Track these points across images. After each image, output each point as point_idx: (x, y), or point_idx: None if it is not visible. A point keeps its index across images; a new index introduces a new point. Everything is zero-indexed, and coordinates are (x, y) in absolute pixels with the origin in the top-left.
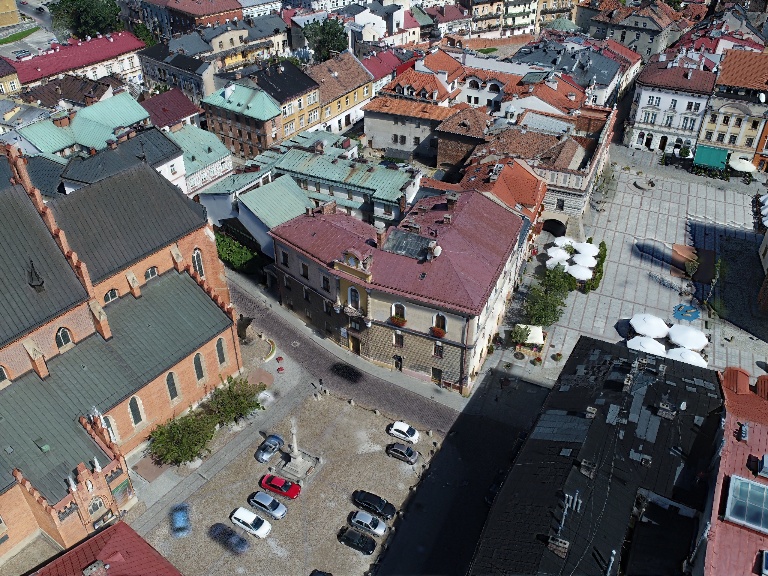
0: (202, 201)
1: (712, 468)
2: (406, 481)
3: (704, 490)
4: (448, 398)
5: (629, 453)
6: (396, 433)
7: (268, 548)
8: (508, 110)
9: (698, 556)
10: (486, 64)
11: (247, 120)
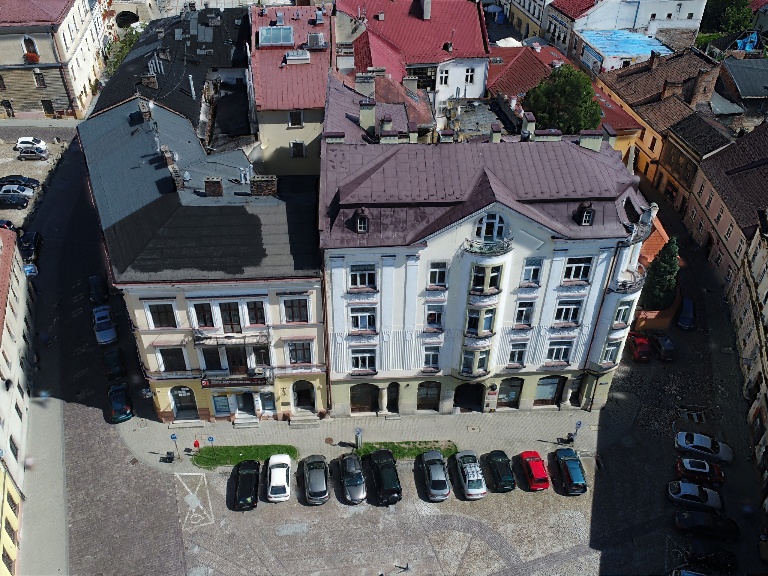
0: None
1: None
2: (43, 169)
3: None
4: (65, 123)
5: (197, 52)
6: (23, 145)
7: None
8: None
9: None
10: None
11: None
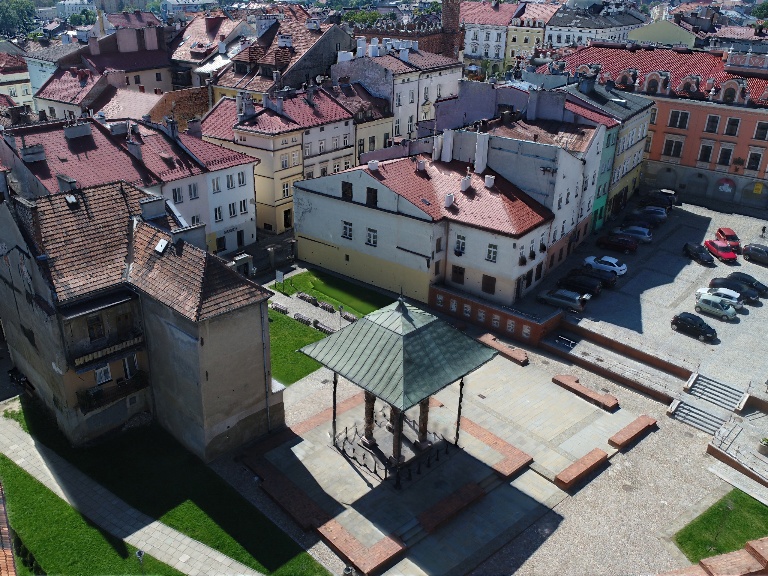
0: None
1: None
2: None
3: None
4: None
5: None
6: None
7: None
8: None
9: None
10: None
11: None
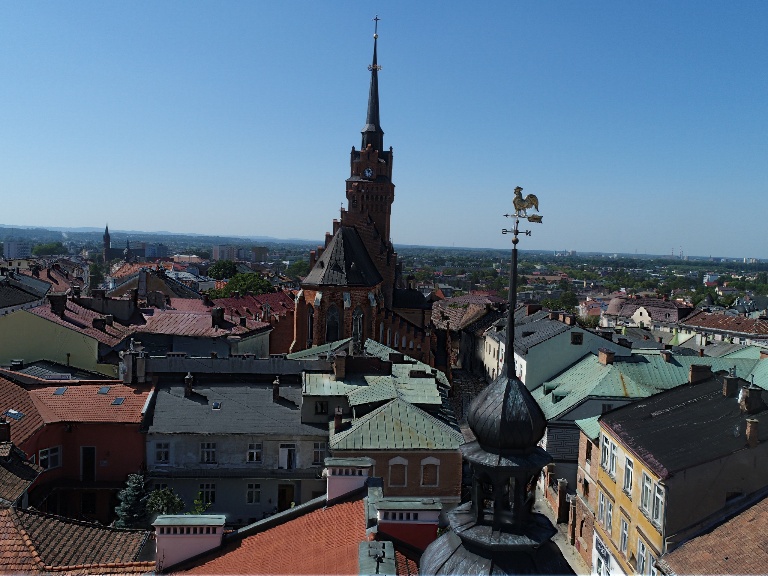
0: None
1: None
2: None
3: None
4: None
5: None
6: None
7: None
8: None
9: None
10: None
11: None
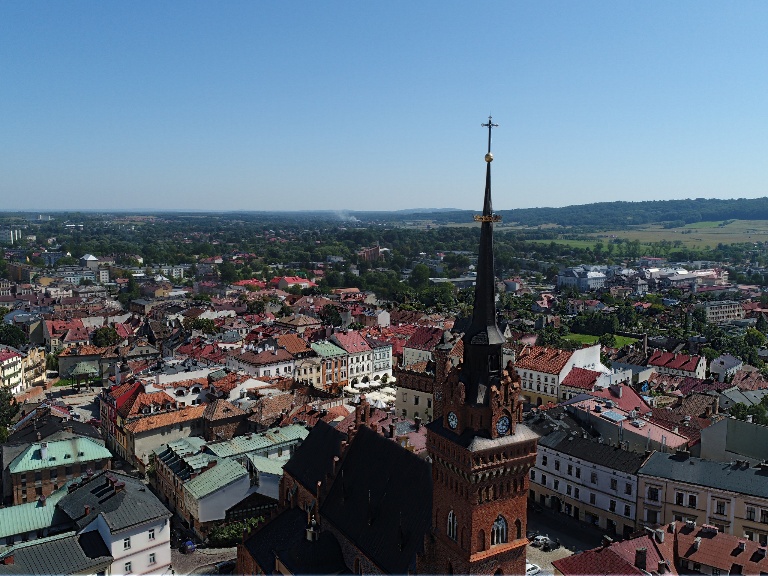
0: (203, 504)
1: (590, 421)
2: None
3: (594, 430)
4: None
5: None
6: None
7: (548, 571)
8: (245, 391)
9: (624, 438)
10: (177, 378)
11: (83, 467)
